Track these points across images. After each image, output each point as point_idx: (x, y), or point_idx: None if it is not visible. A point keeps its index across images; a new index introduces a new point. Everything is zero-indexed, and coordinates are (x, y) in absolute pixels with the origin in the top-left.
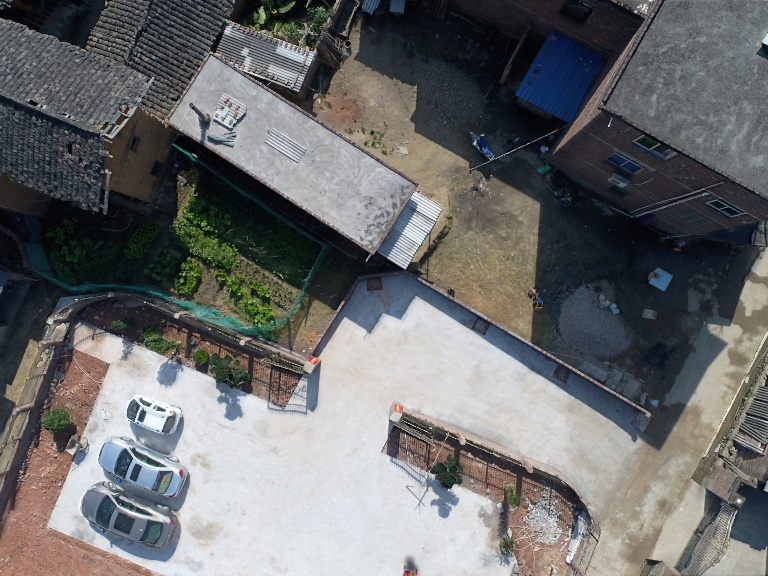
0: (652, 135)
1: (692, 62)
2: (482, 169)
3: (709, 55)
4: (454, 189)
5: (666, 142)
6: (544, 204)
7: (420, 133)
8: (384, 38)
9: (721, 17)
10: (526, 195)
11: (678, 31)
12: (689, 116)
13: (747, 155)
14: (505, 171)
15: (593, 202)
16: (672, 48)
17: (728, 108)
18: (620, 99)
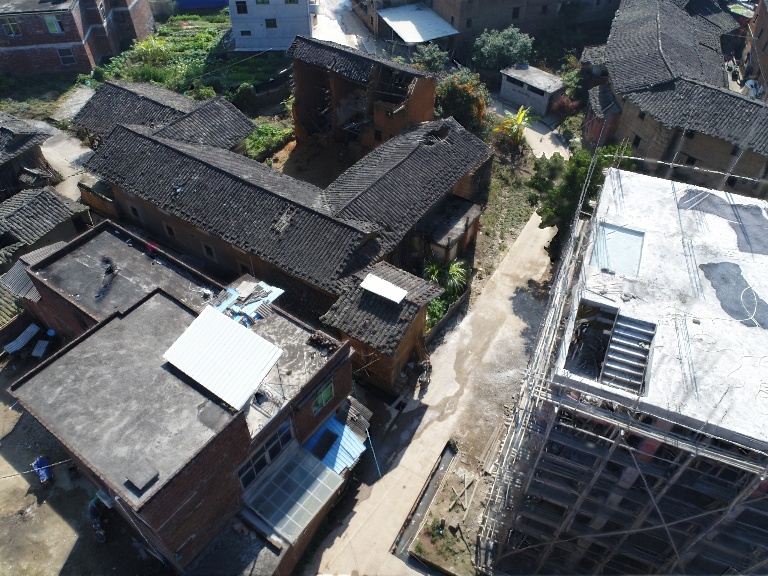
0: (35, 417)
1: (105, 367)
2: (39, 494)
3: (122, 363)
4: (1, 510)
5: (44, 424)
6: (82, 538)
7: (1, 453)
8: (19, 374)
9: (145, 339)
10: (69, 526)
11: (106, 344)
12: (81, 407)
13: (115, 445)
14: (61, 499)
15: (132, 542)
16: (95, 355)
17: (117, 404)
18: (30, 387)
